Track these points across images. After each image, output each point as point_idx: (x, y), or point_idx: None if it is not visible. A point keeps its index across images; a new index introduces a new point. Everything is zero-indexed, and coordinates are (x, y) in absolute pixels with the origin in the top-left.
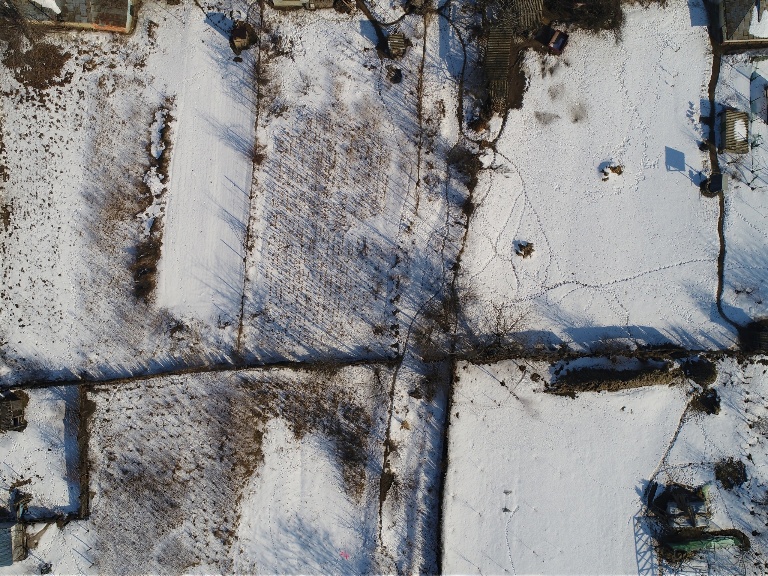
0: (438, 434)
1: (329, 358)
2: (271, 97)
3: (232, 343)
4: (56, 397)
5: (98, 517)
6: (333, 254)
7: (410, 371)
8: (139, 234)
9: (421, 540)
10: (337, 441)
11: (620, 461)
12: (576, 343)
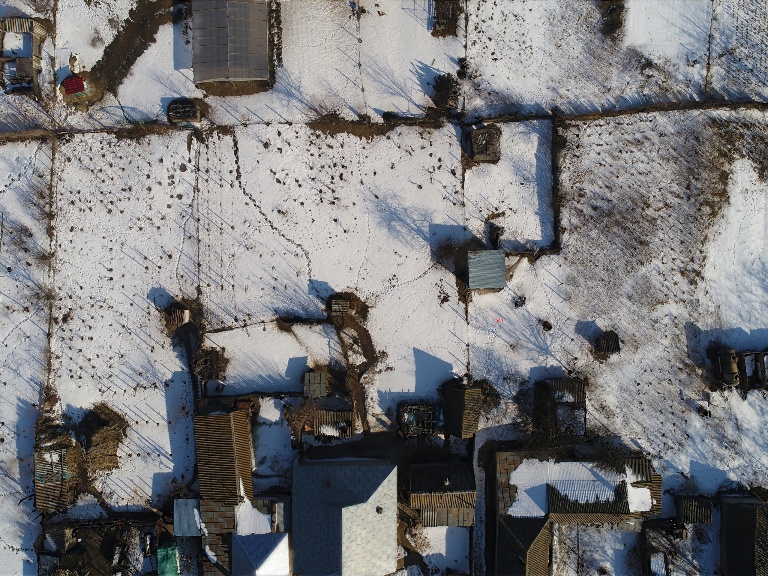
0: None
1: None
2: None
3: (701, 81)
4: (529, 130)
5: (569, 252)
6: None
7: None
8: None
9: None
10: None
11: None
12: None
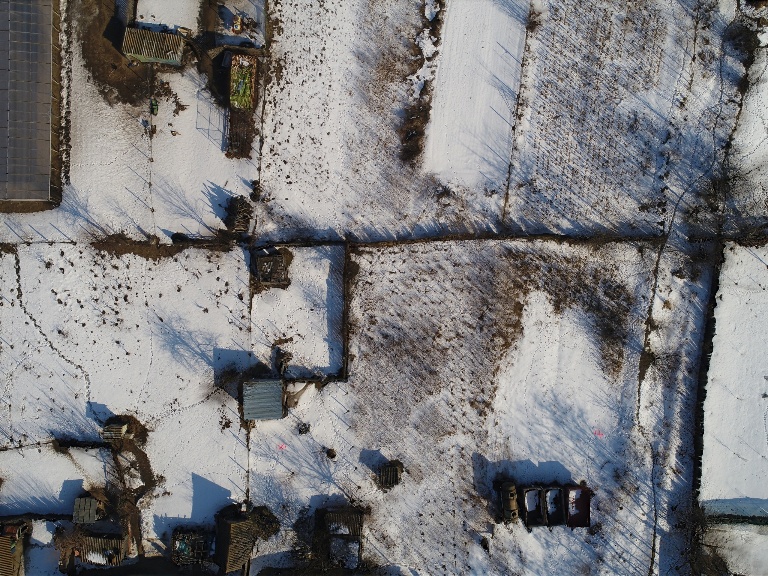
0: (702, 315)
1: (593, 233)
2: None
3: (498, 212)
4: (321, 256)
5: (357, 380)
6: (603, 127)
7: (674, 250)
8: (409, 96)
9: (679, 421)
10: (596, 318)
11: None
12: None
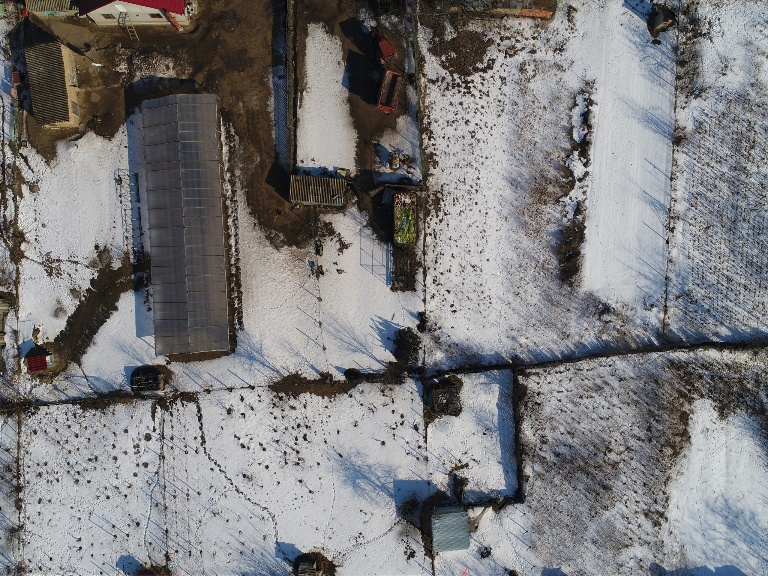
0: None
1: (752, 338)
2: (689, 79)
3: (659, 325)
4: (490, 381)
5: (533, 500)
6: (754, 234)
7: None
8: (563, 218)
9: None
10: (760, 421)
11: None
12: None
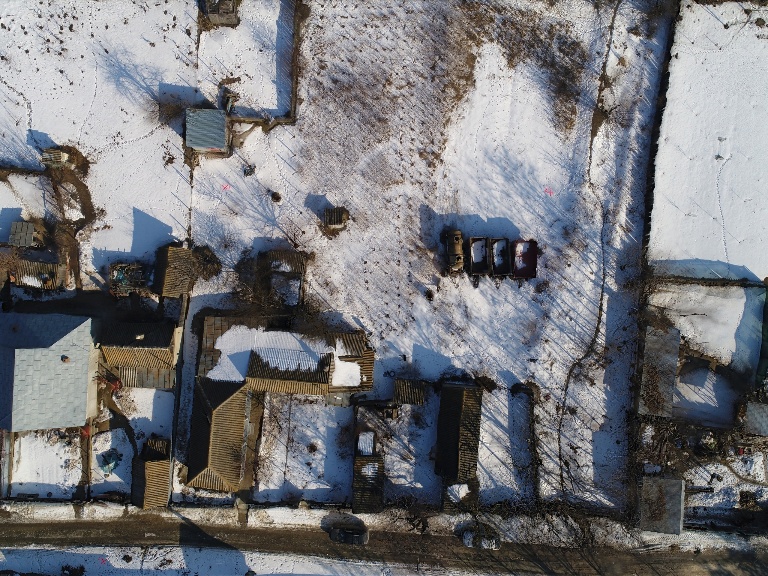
0: (656, 72)
1: None
2: None
3: None
4: None
5: (305, 124)
6: None
7: (631, 7)
8: None
9: (630, 179)
10: (550, 74)
11: None
12: None
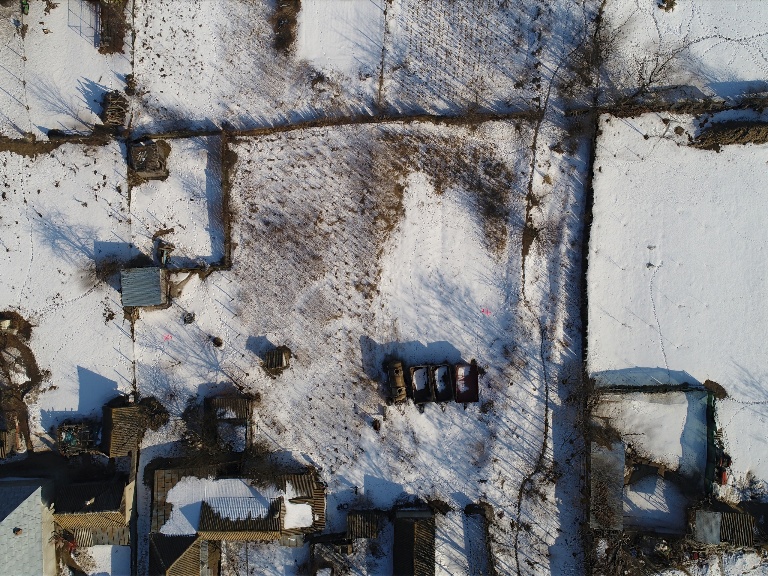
0: (581, 187)
1: (470, 112)
2: None
3: (373, 95)
4: (198, 146)
5: (240, 268)
6: (473, 7)
7: (552, 125)
8: None
9: (565, 294)
10: (478, 197)
11: (766, 215)
12: (720, 97)
